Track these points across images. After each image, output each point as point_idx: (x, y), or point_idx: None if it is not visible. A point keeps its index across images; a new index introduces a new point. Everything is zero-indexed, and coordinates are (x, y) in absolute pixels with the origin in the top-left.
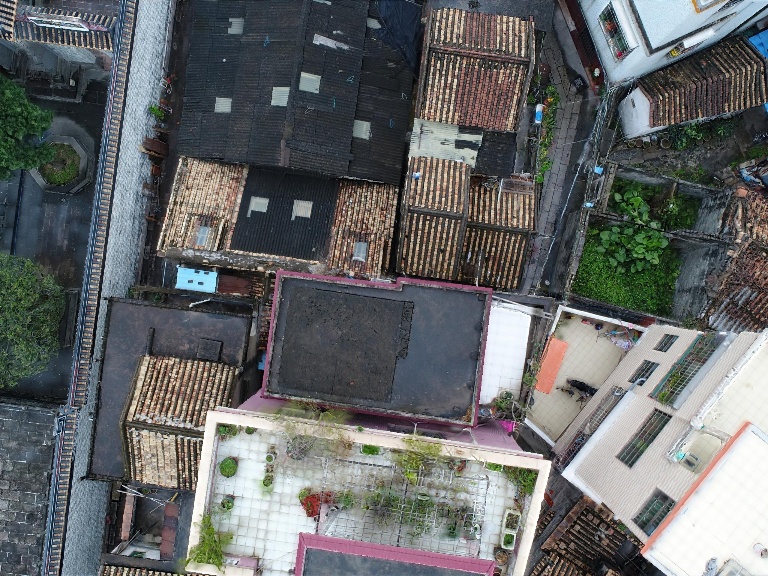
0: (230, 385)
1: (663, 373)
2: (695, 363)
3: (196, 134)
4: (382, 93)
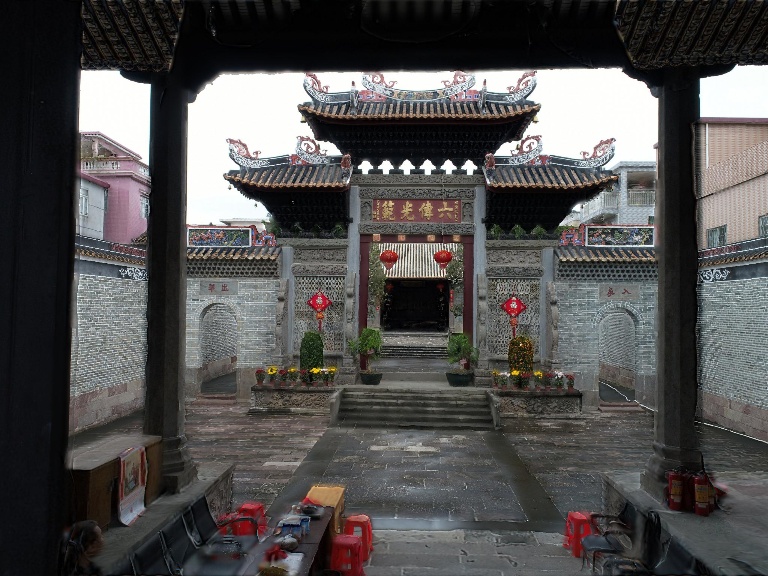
0: (141, 235)
1: None
2: None
3: None
4: None
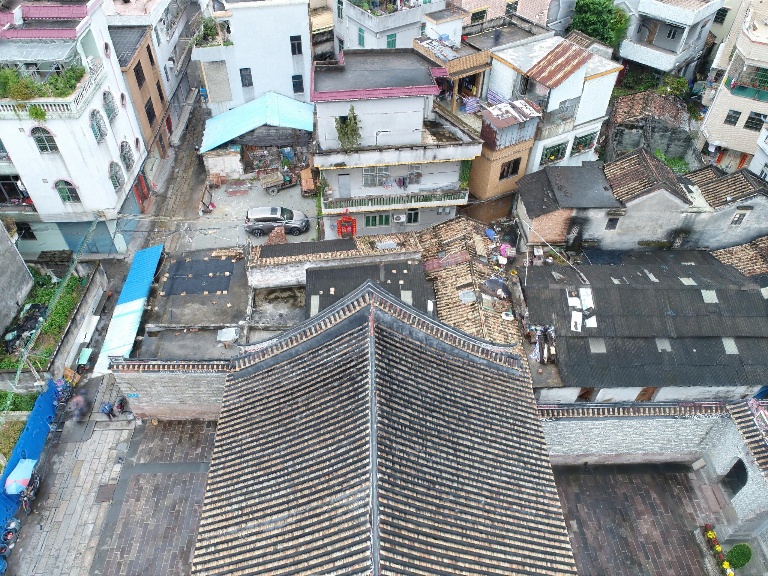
0: None
1: (761, 103)
2: (764, 76)
3: (763, 369)
4: (656, 260)
